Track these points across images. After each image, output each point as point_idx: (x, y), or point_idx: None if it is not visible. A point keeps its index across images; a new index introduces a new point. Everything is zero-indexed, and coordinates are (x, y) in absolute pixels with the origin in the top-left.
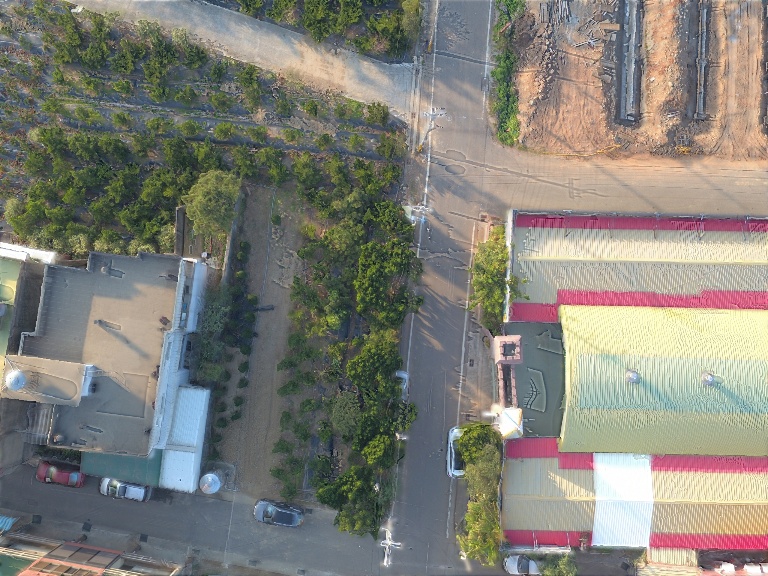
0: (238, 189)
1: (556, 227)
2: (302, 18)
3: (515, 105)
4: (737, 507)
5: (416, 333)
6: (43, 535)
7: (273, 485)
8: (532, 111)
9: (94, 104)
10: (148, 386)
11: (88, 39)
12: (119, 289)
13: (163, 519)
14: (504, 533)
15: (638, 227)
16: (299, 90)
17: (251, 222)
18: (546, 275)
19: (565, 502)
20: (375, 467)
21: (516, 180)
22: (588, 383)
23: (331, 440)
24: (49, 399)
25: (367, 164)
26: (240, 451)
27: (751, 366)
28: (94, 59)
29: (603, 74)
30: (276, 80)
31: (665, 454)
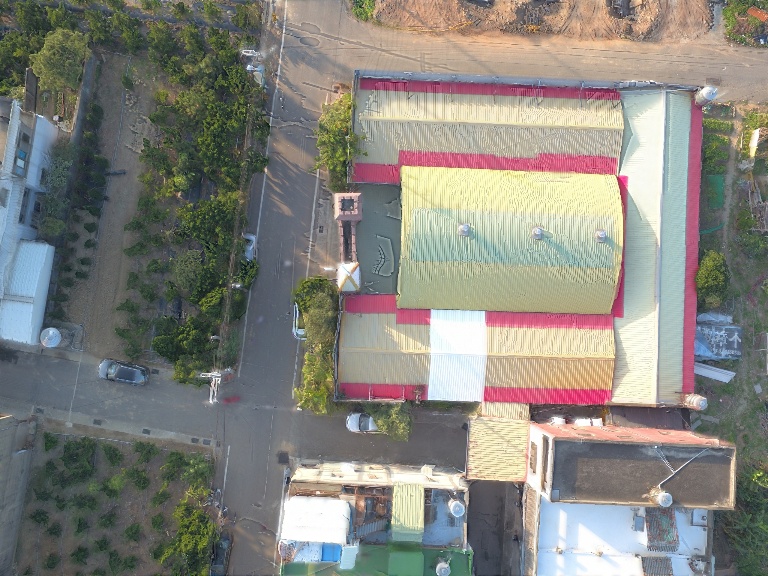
0: (83, 45)
1: (399, 90)
2: None
3: None
4: (568, 362)
5: (267, 199)
6: None
7: (120, 345)
8: None
9: None
10: None
11: None
12: None
13: (8, 378)
14: (341, 386)
15: (479, 92)
16: None
17: (105, 88)
18: (387, 136)
19: (401, 355)
20: (214, 319)
21: (369, 53)
22: (424, 238)
23: (179, 302)
24: None
25: (221, 33)
26: (88, 312)
27: (582, 225)
28: None
29: None
30: None
31: (501, 311)
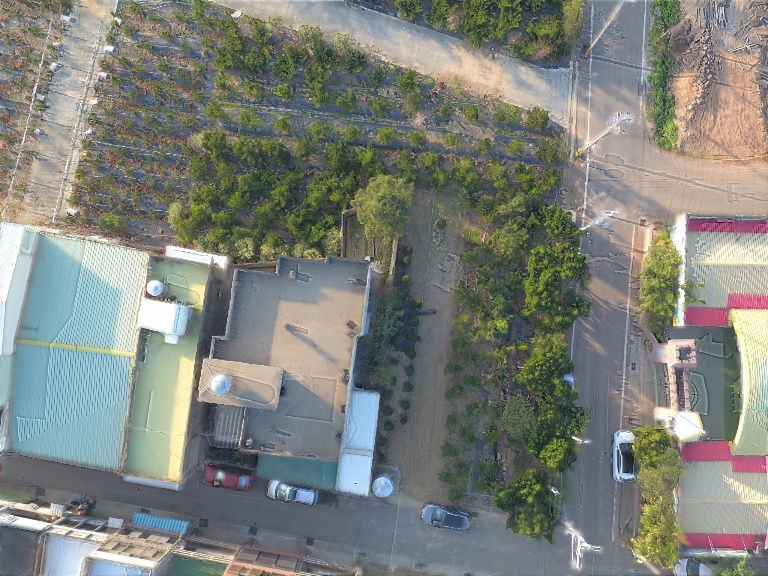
0: (411, 193)
1: (726, 231)
2: (460, 23)
3: (671, 110)
4: None
5: (578, 337)
6: (215, 539)
7: (438, 488)
8: (690, 116)
9: (253, 109)
10: (336, 390)
11: (247, 44)
12: (306, 293)
13: (329, 523)
14: (679, 536)
15: None
16: (457, 95)
17: (412, 226)
18: (718, 279)
19: (740, 505)
20: (551, 470)
21: (675, 184)
22: (764, 386)
23: (495, 443)
24: (247, 403)
25: (528, 168)
26: (405, 455)
27: None
28: (257, 64)
29: (760, 79)
30: (434, 85)
31: None
